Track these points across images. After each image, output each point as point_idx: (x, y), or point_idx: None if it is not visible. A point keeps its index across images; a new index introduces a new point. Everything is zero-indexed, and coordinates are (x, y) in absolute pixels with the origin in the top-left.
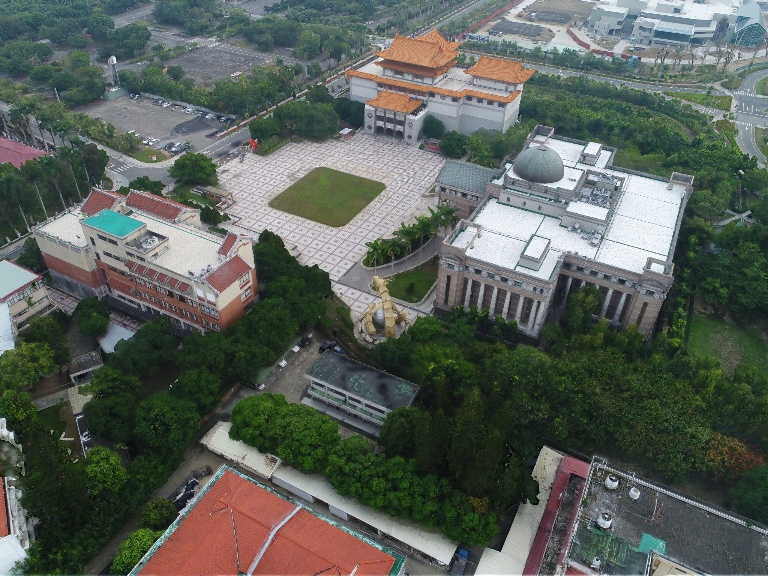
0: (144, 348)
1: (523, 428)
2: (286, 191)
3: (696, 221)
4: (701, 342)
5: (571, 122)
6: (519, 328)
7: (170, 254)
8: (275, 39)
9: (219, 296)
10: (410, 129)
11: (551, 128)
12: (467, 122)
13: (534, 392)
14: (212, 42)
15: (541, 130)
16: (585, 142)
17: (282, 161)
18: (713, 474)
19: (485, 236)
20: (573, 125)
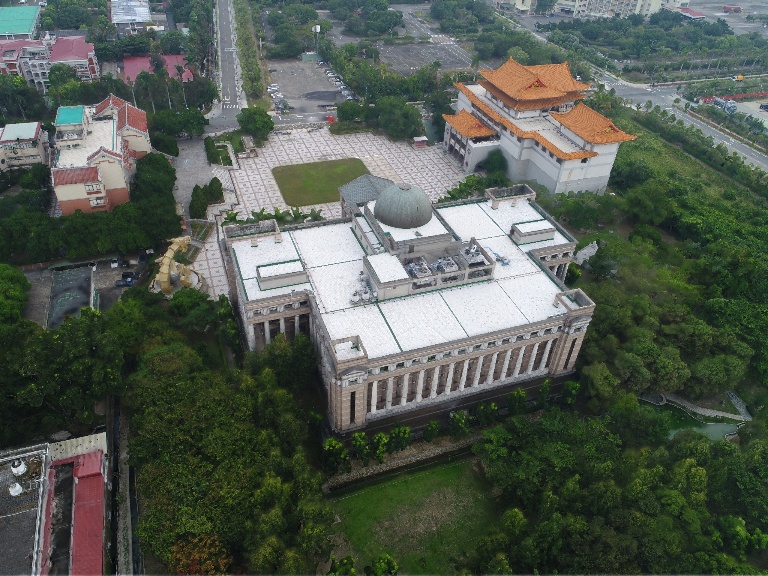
0: (8, 203)
1: (20, 377)
2: (301, 164)
3: (594, 368)
4: (422, 486)
5: (655, 214)
6: (249, 345)
7: (78, 150)
8: (498, 50)
9: (58, 188)
10: (468, 156)
11: (533, 192)
12: (531, 170)
13: (60, 358)
14: (449, 41)
15: (526, 191)
16: (554, 221)
17: (338, 143)
18: (167, 568)
19: (282, 244)
20: (655, 219)
